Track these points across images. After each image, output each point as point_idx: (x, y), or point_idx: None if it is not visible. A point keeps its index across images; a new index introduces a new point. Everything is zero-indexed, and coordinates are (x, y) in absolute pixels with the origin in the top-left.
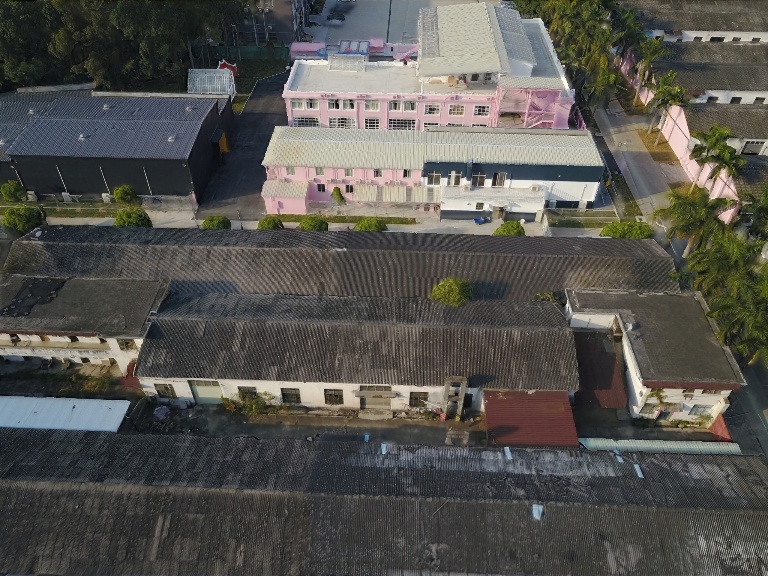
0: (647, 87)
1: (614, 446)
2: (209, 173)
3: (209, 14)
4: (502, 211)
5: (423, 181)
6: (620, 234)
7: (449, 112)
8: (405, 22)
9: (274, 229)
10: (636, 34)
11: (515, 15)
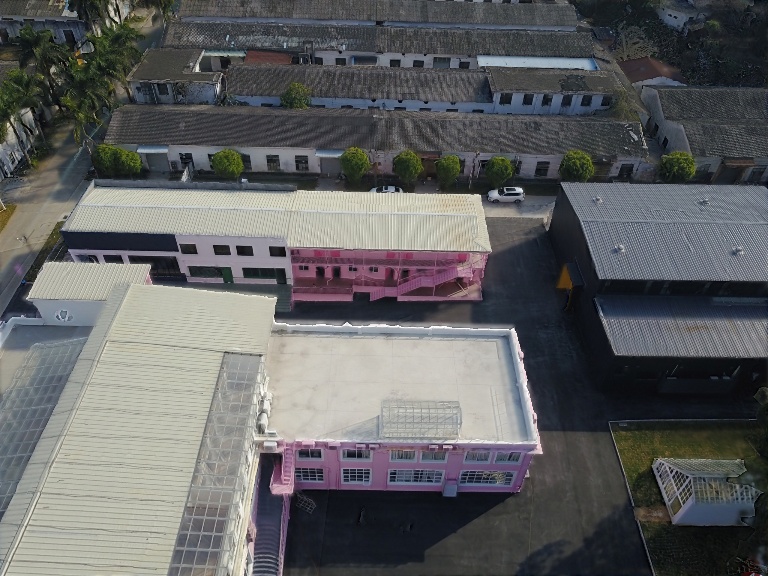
0: None
1: (230, 53)
2: None
3: None
4: None
5: None
6: None
7: None
8: None
9: None
10: None
11: None
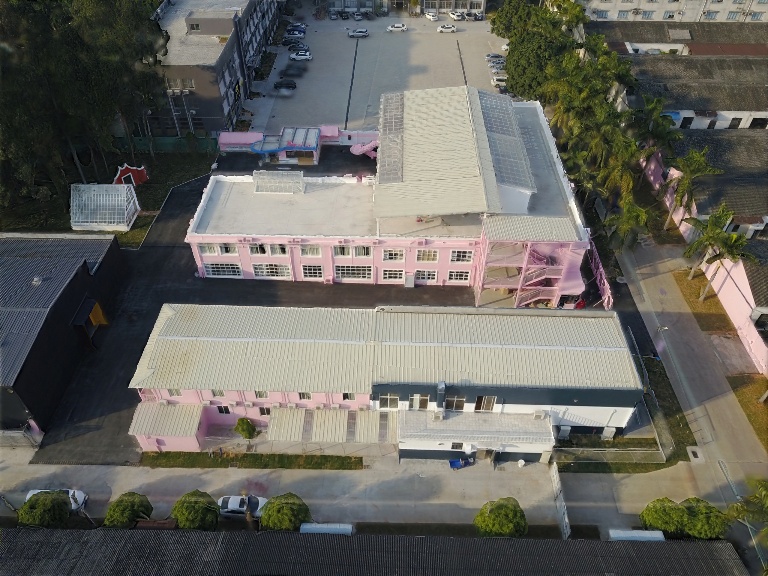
0: (689, 223)
1: None
2: (71, 369)
3: (89, 120)
4: (491, 451)
5: (373, 405)
6: (676, 527)
7: (417, 258)
8: (370, 89)
9: (131, 523)
10: (666, 134)
11: (506, 103)
